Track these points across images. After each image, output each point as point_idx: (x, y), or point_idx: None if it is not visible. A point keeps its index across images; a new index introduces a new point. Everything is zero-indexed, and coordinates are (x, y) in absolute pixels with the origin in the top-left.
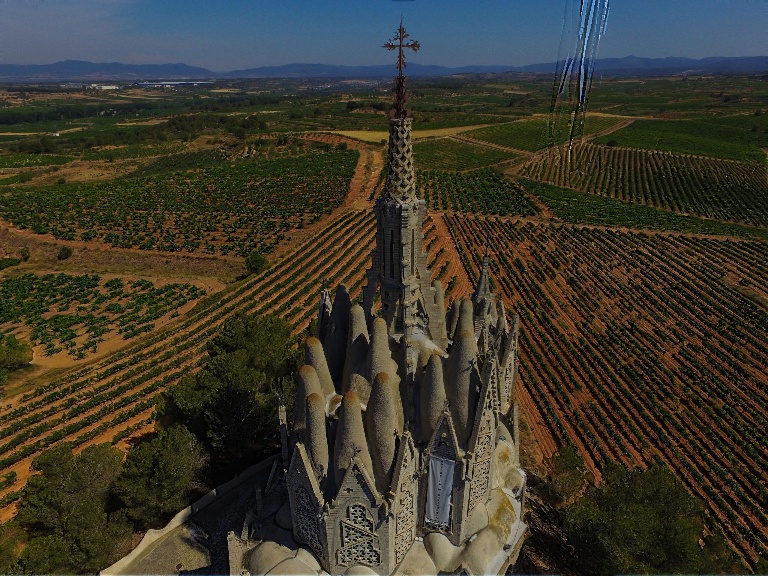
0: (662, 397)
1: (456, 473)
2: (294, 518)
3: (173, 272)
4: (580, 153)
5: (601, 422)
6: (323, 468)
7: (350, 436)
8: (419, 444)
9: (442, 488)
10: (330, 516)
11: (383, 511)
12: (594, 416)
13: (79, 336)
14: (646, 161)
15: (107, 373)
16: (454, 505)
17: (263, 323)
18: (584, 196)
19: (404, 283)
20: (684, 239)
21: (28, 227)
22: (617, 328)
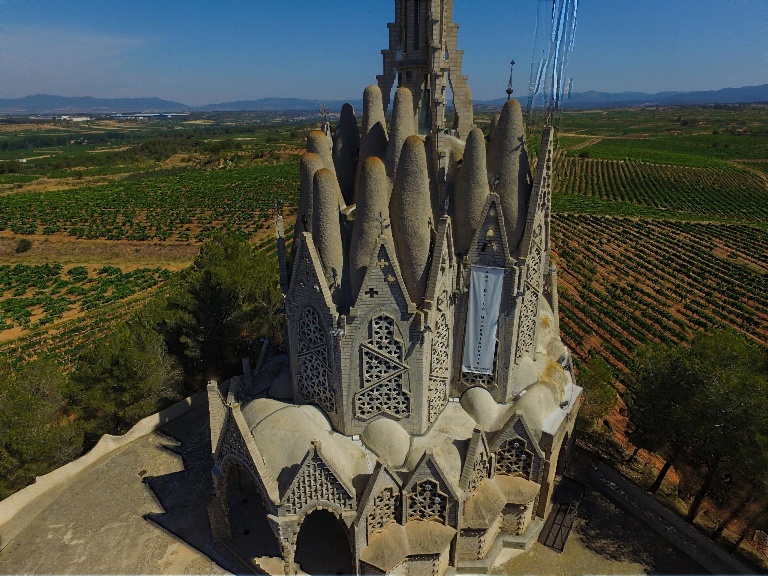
0: (676, 342)
1: (505, 289)
2: (295, 369)
3: (143, 260)
4: (557, 156)
5: (619, 360)
6: (336, 274)
7: (373, 217)
8: (457, 253)
9: (486, 314)
10: (346, 337)
11: (417, 326)
12: (610, 357)
13: (35, 315)
14: (618, 169)
15: (64, 336)
16: (500, 341)
17: (245, 249)
18: (563, 195)
19: (434, 44)
20: (667, 223)
21: None
22: (617, 289)
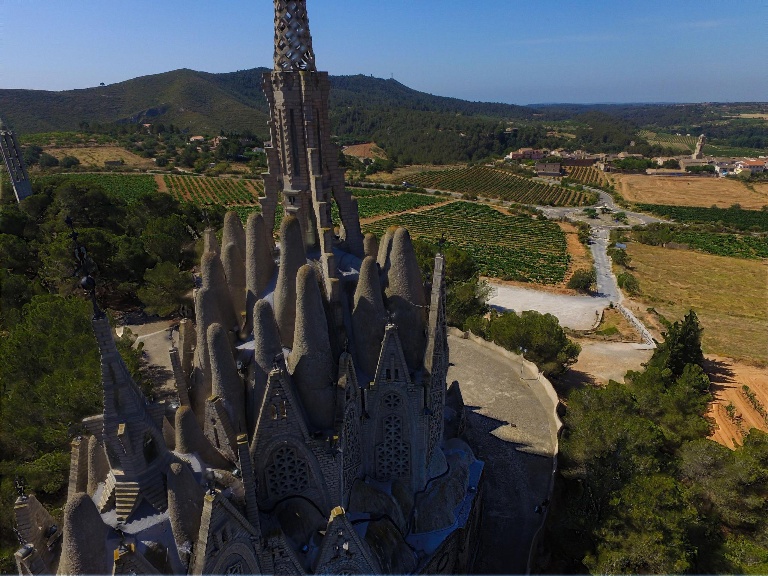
0: None
1: None
2: None
3: None
4: None
5: None
6: None
7: None
8: None
9: None
10: None
11: None
12: None
13: None
14: None
15: None
16: None
17: None
18: None
19: None
20: None
21: None
22: None
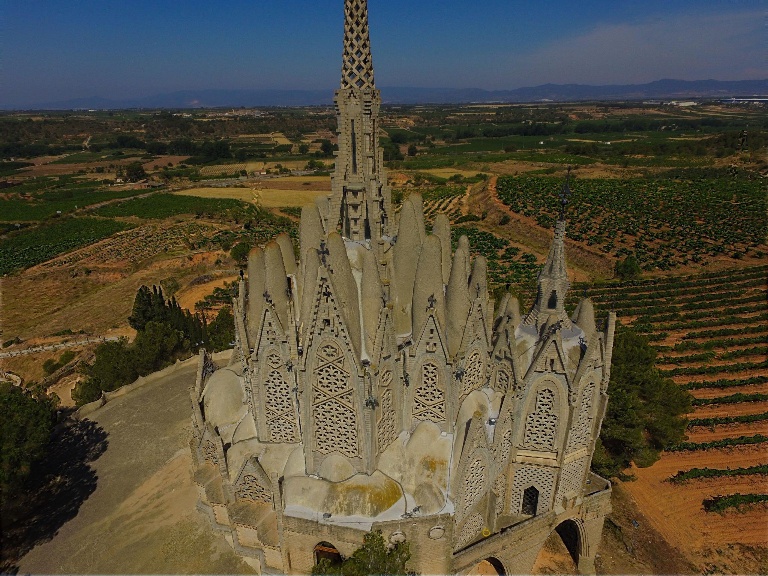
0: None
1: None
2: None
3: None
4: None
5: None
6: None
7: (249, 286)
8: None
9: None
10: None
11: None
12: None
13: None
14: None
15: None
16: None
17: None
18: None
19: None
20: None
21: (503, 198)
22: None
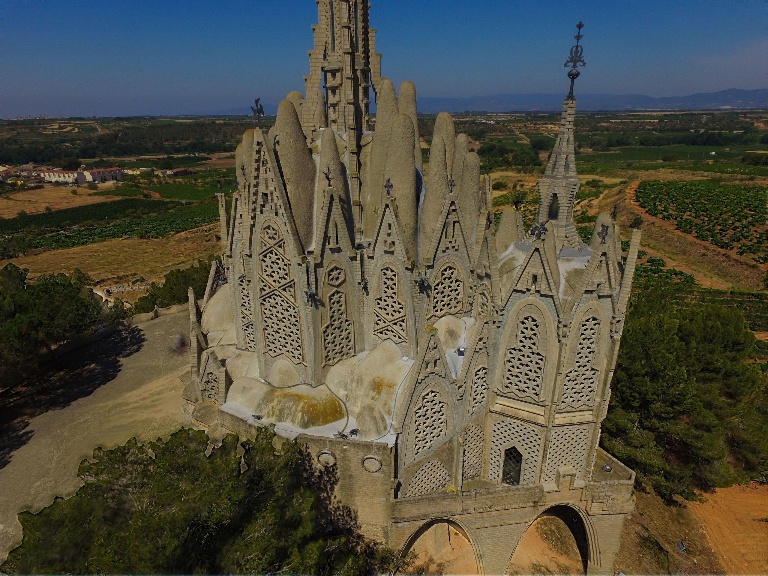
0: None
1: None
2: None
3: (699, 265)
4: None
5: None
6: None
7: None
8: None
9: None
10: None
11: None
12: None
13: None
14: None
15: None
16: None
17: None
18: None
19: None
20: None
21: (641, 201)
22: None
